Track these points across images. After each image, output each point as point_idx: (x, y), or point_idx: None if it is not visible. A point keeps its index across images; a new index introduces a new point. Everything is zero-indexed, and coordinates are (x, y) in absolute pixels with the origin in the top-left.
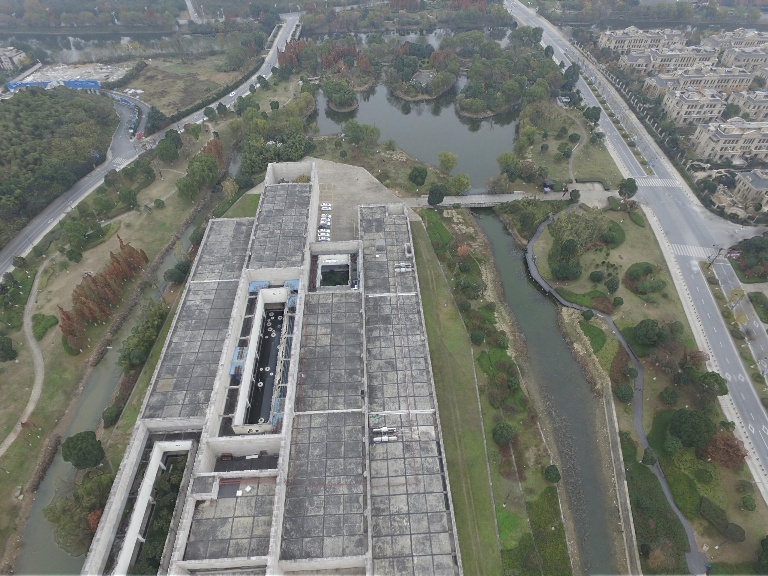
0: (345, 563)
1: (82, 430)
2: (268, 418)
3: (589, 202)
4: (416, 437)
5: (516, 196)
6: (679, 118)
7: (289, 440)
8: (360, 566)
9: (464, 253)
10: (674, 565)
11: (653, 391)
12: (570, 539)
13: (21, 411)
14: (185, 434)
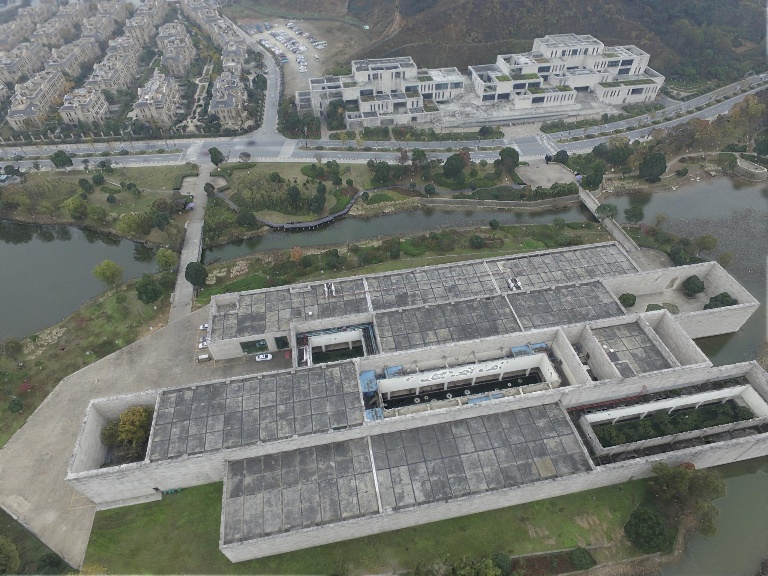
0: None
1: None
2: None
3: (214, 186)
4: (509, 270)
5: (192, 228)
6: (97, 120)
7: None
8: None
9: (302, 252)
10: (522, 192)
11: (421, 183)
12: None
13: None
14: None
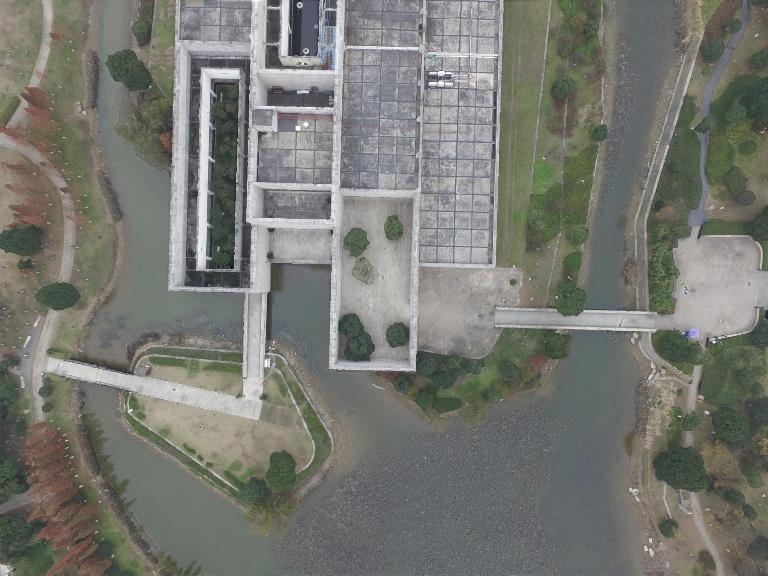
0: (396, 194)
1: (115, 46)
2: (312, 48)
3: None
4: (473, 85)
5: None
6: None
7: (342, 78)
8: (408, 197)
9: None
10: (677, 218)
11: (746, 51)
12: (595, 191)
13: (40, 18)
14: (229, 61)
